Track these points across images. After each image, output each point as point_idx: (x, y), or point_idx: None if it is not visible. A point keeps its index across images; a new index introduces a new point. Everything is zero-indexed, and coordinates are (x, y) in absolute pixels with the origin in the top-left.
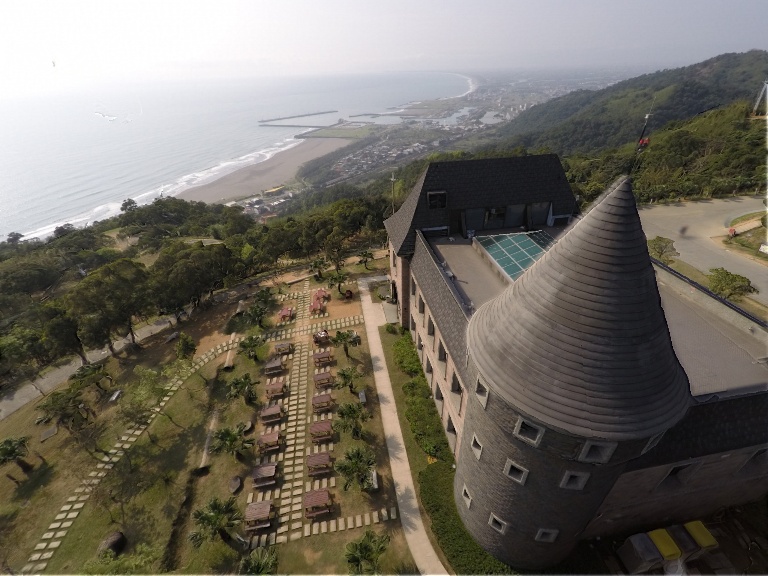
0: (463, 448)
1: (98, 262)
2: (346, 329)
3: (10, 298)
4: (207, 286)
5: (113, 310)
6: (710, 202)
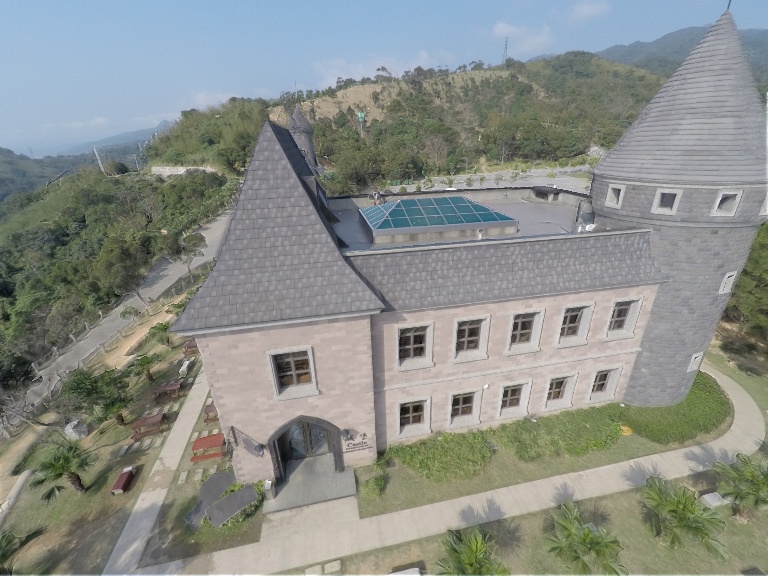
0: (694, 323)
1: None
2: None
3: None
4: None
5: None
6: (218, 220)
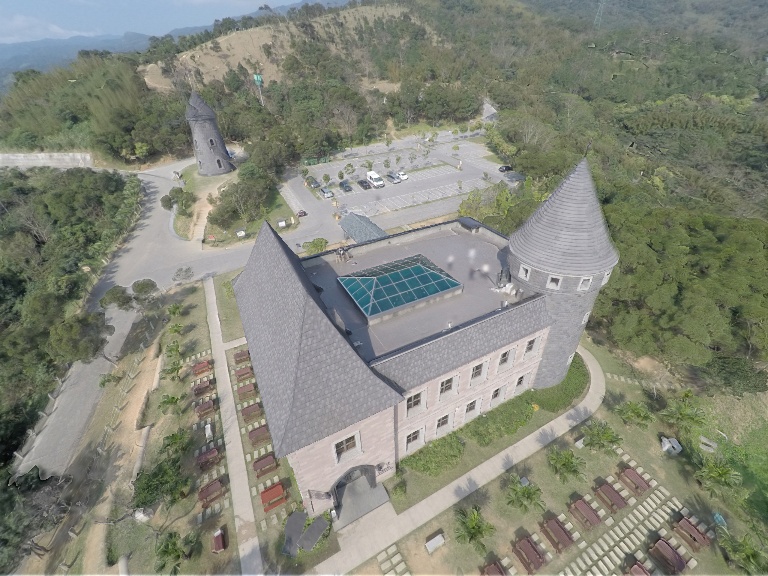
0: None
1: None
2: (417, 575)
3: None
4: None
5: None
6: (136, 236)
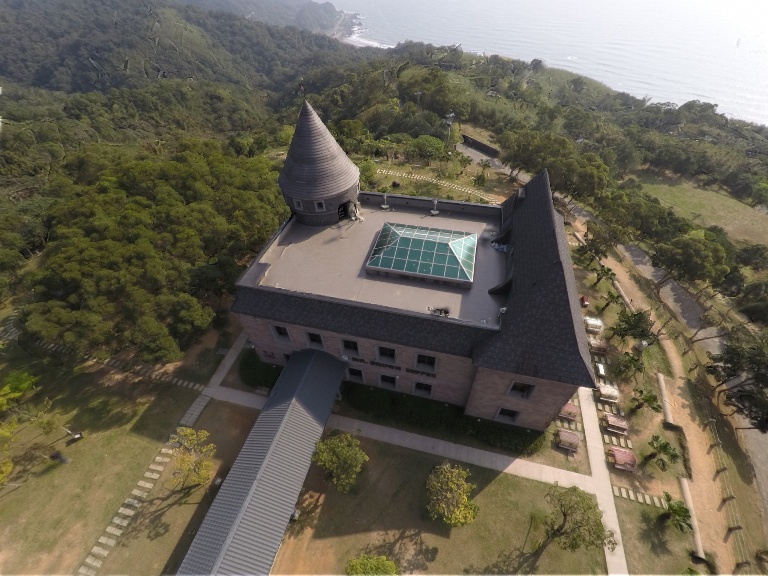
0: None
1: (740, 189)
2: None
3: (634, 155)
4: (563, 189)
5: (520, 152)
6: None
